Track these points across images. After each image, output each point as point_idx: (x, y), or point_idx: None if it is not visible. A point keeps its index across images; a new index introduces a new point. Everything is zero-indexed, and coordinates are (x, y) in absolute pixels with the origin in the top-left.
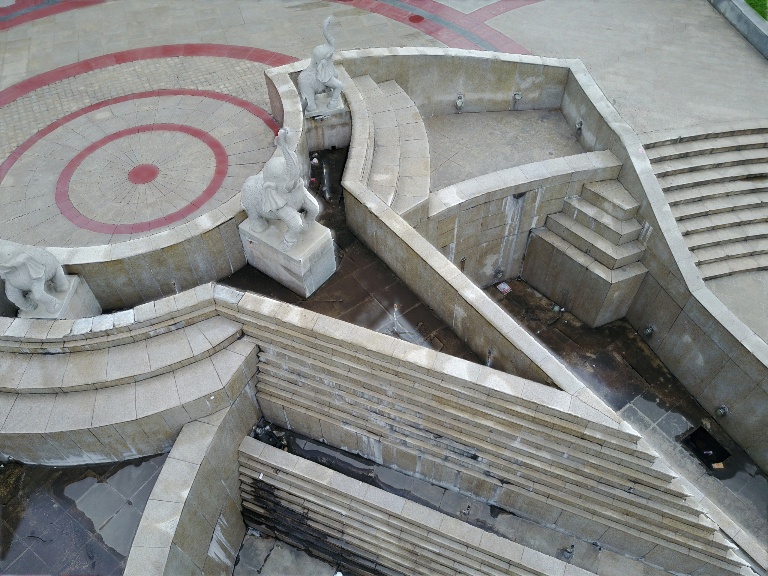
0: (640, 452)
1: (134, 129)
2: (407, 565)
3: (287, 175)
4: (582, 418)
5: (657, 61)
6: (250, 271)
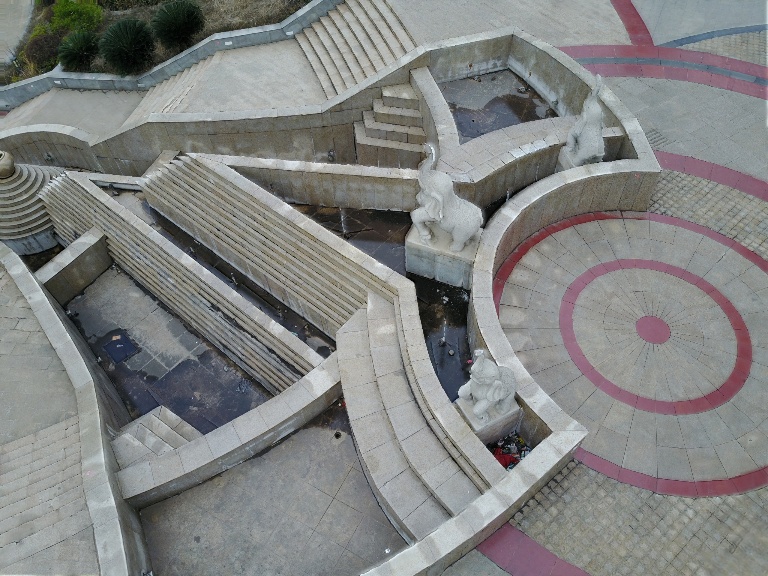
0: None
1: (728, 393)
2: None
3: None
4: None
5: None
6: None
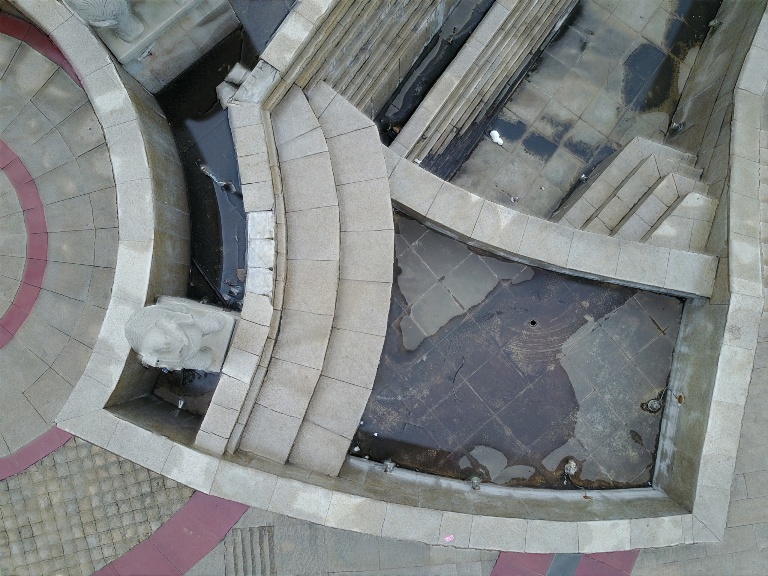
0: None
1: None
2: None
3: None
4: None
5: None
6: (167, 96)
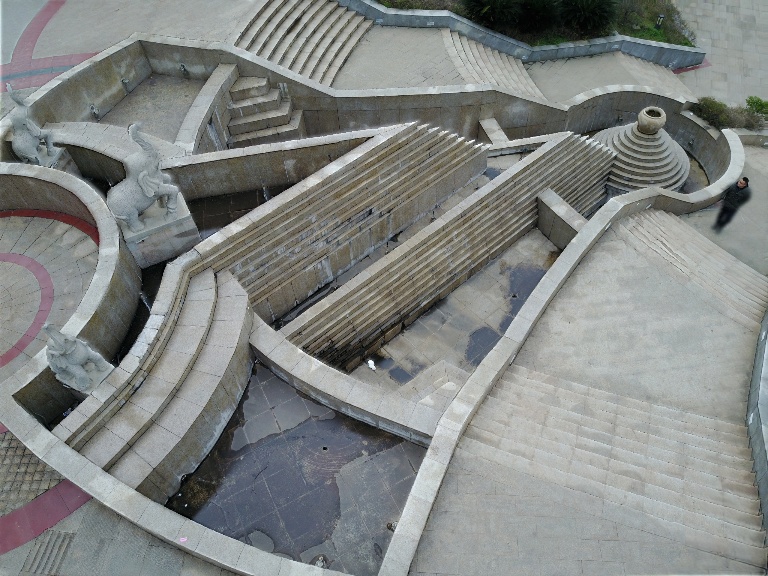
0: (421, 130)
1: None
2: (393, 305)
3: (150, 157)
4: (393, 136)
5: (171, 8)
6: (149, 271)
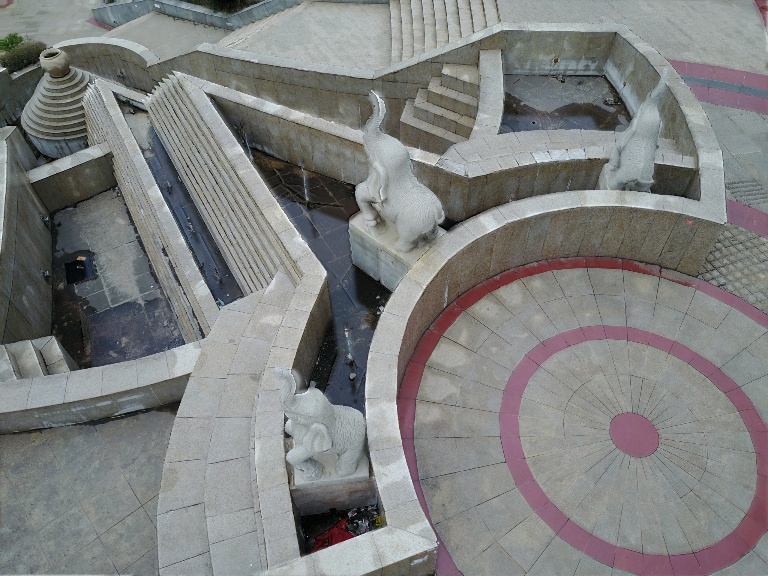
0: None
1: (708, 565)
2: None
3: None
4: None
5: None
6: None
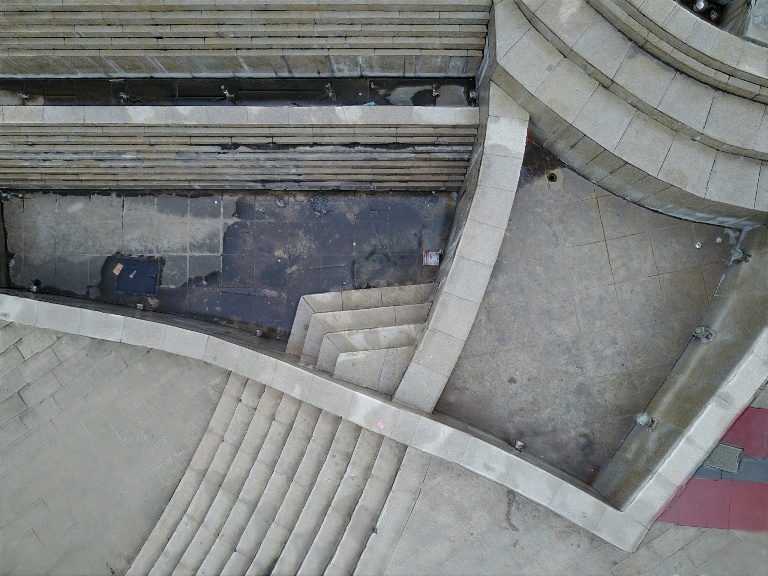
0: None
1: None
2: None
3: None
4: None
5: None
6: None
